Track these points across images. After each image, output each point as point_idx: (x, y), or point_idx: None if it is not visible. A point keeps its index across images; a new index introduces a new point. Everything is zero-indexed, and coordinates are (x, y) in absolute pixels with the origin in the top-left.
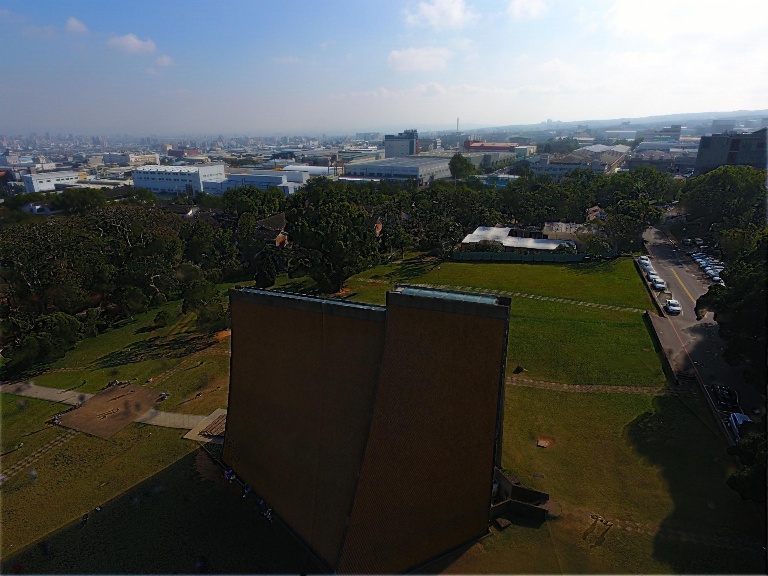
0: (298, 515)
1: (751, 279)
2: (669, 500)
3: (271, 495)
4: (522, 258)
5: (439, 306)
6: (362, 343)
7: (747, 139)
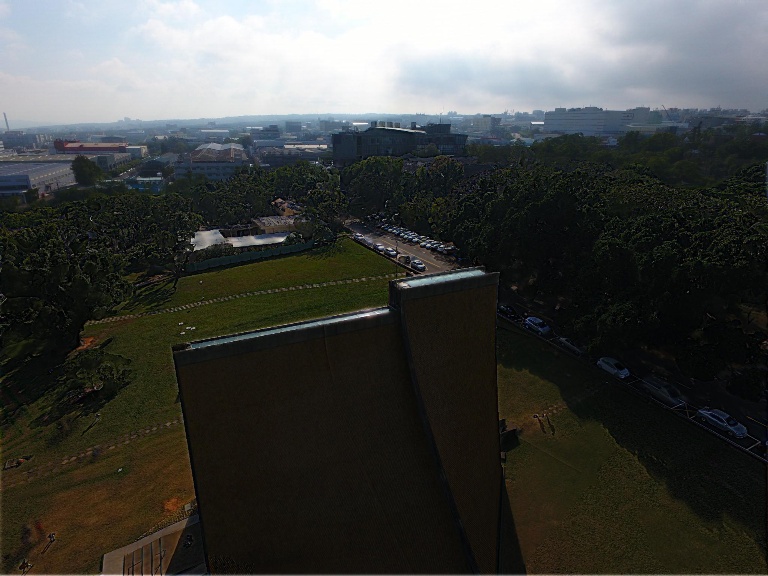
0: (385, 567)
1: (495, 229)
2: (551, 384)
3: (333, 575)
4: (261, 255)
5: (449, 288)
6: (375, 353)
7: (365, 136)
